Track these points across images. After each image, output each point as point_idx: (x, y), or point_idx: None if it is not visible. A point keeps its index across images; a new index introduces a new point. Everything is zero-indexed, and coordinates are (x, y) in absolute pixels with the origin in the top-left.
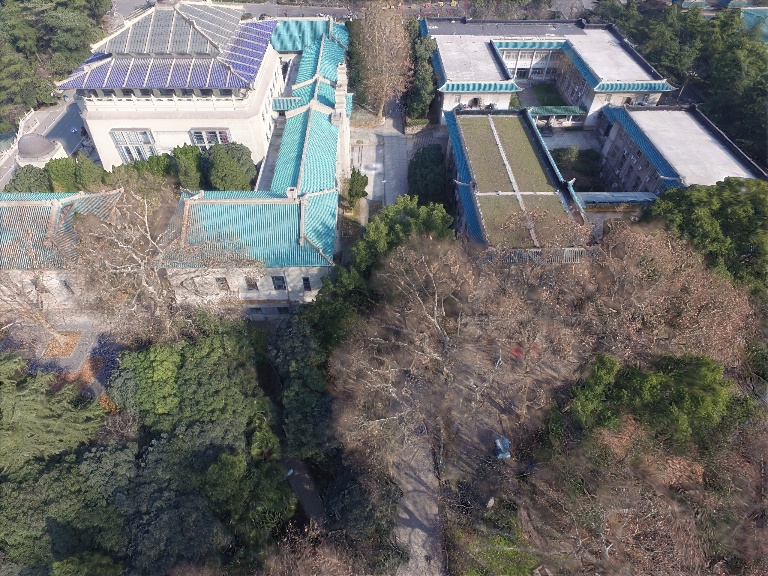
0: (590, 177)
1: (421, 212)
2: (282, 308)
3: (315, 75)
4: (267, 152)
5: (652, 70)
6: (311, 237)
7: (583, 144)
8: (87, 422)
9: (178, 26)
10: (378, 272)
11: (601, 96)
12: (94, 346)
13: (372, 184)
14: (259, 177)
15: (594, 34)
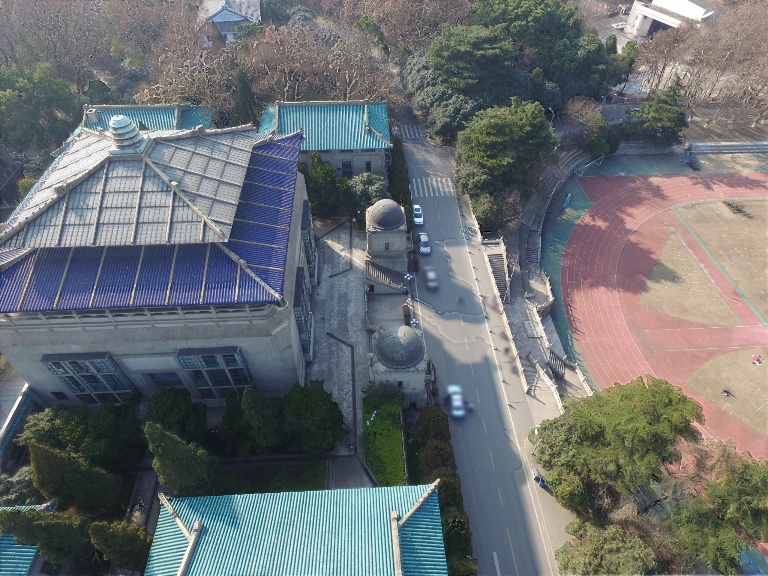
0: None
1: (4, 67)
2: None
3: None
4: None
5: None
6: None
7: None
8: (235, 69)
9: None
10: None
11: None
12: None
13: None
14: None
15: None
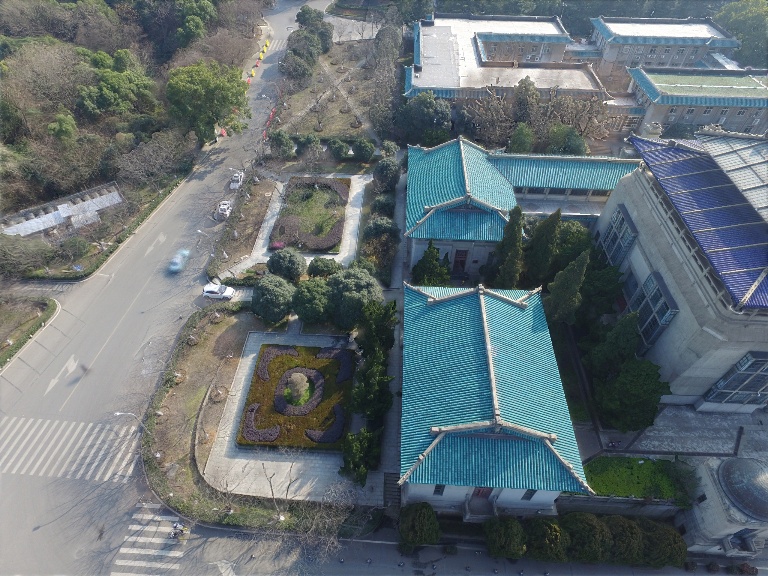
0: None
1: None
2: None
3: None
4: None
5: (536, 18)
6: None
7: None
8: None
9: None
10: None
11: None
12: None
13: None
14: None
15: (448, 24)
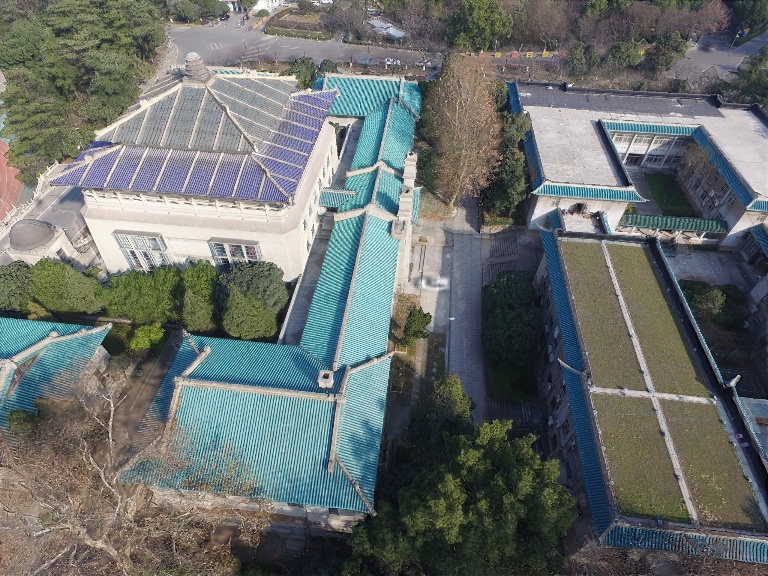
0: (735, 333)
1: (523, 487)
2: (296, 527)
3: (376, 163)
4: (305, 265)
5: None
6: (346, 456)
7: (719, 273)
8: None
9: (207, 111)
10: (441, 545)
11: (753, 214)
12: (34, 567)
13: (434, 306)
14: (290, 308)
15: (734, 117)
